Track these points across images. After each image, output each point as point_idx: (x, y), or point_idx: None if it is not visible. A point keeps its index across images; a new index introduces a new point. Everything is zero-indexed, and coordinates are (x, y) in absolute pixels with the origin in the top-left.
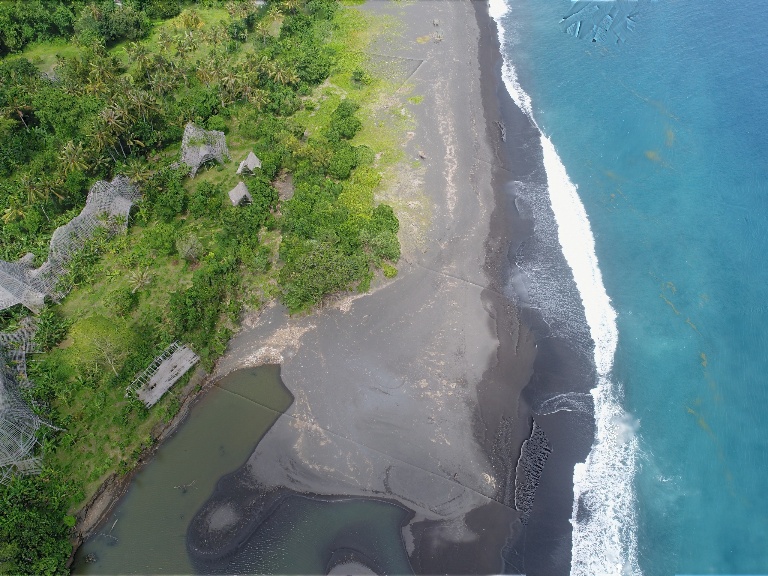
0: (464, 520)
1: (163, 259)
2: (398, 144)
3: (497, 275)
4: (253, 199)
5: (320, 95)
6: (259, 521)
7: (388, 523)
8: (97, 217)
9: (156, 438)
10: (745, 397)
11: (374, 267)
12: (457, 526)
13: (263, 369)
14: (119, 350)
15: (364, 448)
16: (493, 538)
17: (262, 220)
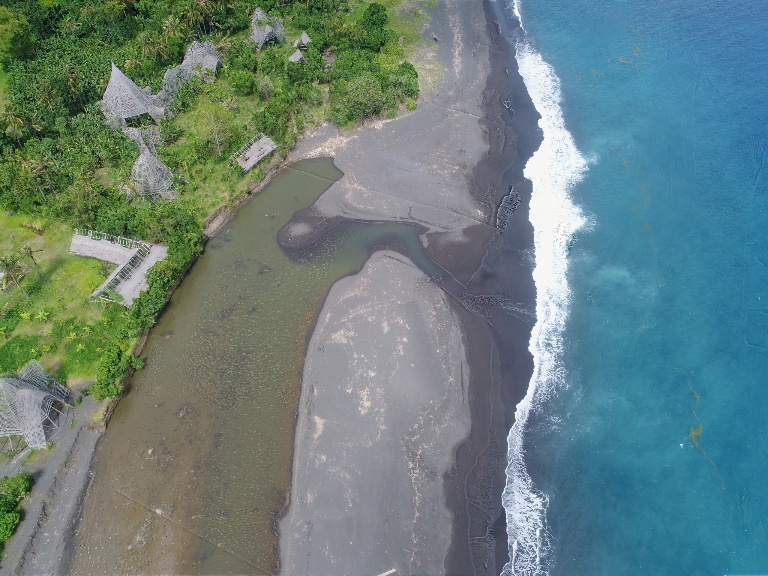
0: (462, 232)
1: (243, 98)
2: (417, 31)
3: (490, 111)
4: (308, 61)
5: (354, 3)
6: (324, 231)
7: (411, 234)
8: (193, 68)
9: (250, 191)
10: (655, 158)
11: (400, 101)
12: (457, 234)
13: (321, 159)
14: (226, 129)
15: (394, 197)
16: (481, 240)
17: (315, 75)
